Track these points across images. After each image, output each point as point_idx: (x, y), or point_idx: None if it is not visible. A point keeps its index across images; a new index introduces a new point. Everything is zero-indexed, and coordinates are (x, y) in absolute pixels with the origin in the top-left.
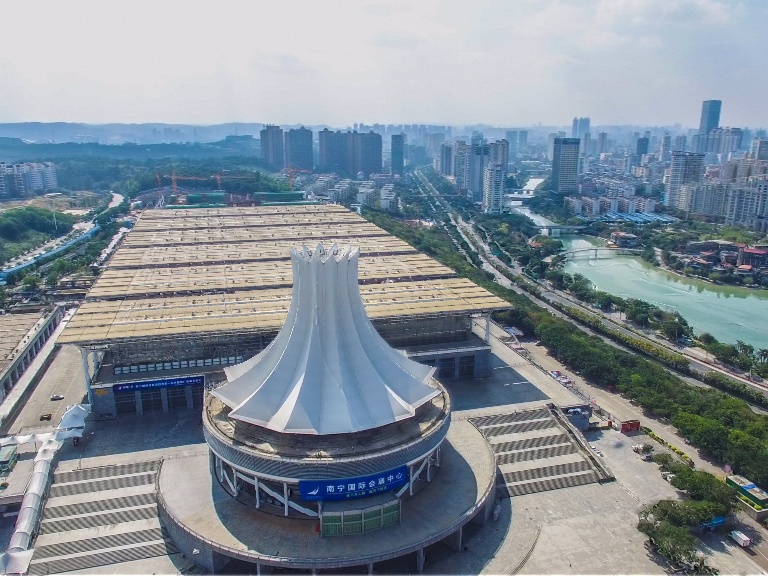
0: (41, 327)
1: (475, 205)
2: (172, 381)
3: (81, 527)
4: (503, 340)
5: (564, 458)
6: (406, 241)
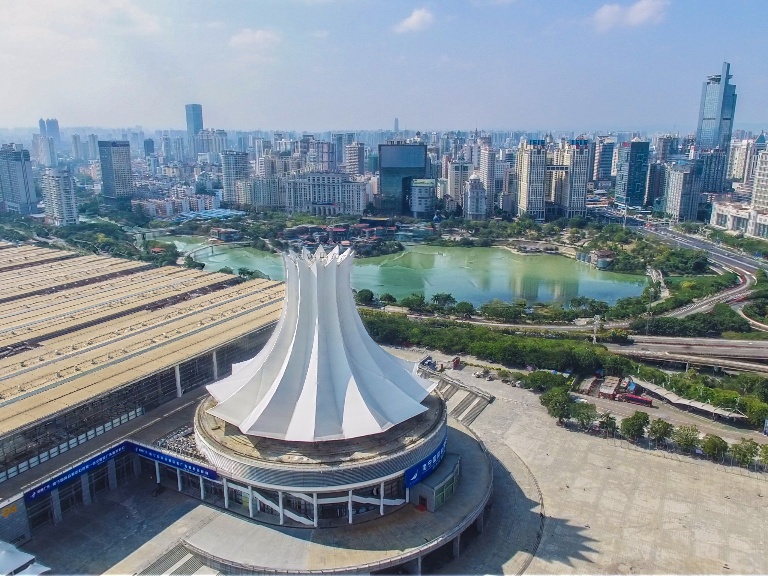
0: None
1: (32, 219)
2: (93, 461)
3: None
4: None
5: (458, 396)
6: None
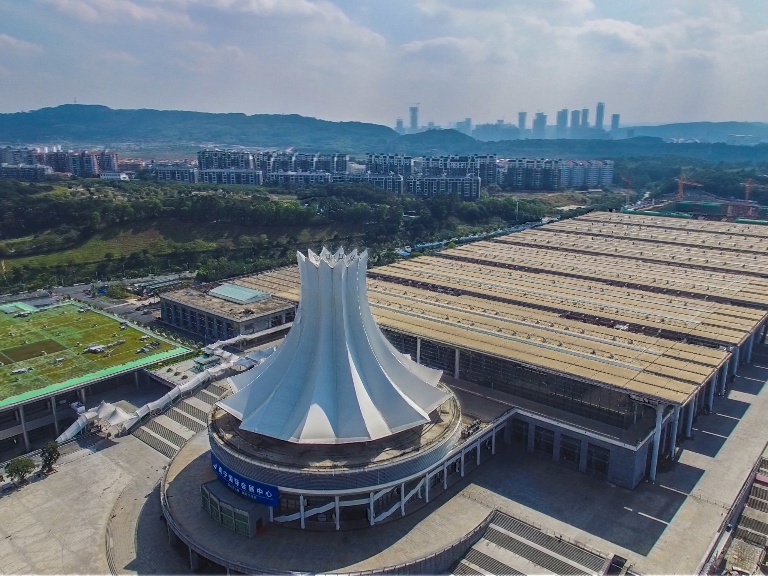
0: None
1: None
2: None
3: (179, 421)
4: (763, 464)
5: None
6: None
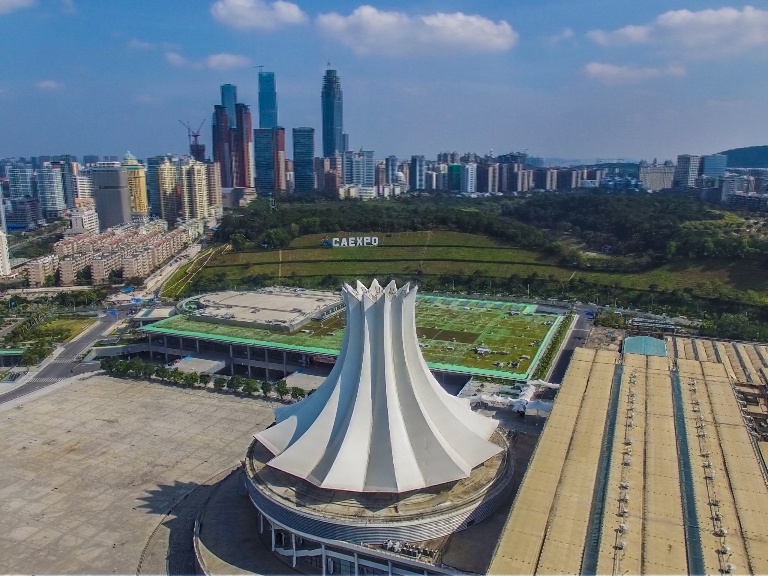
0: None
1: None
2: None
3: None
4: None
5: None
6: None
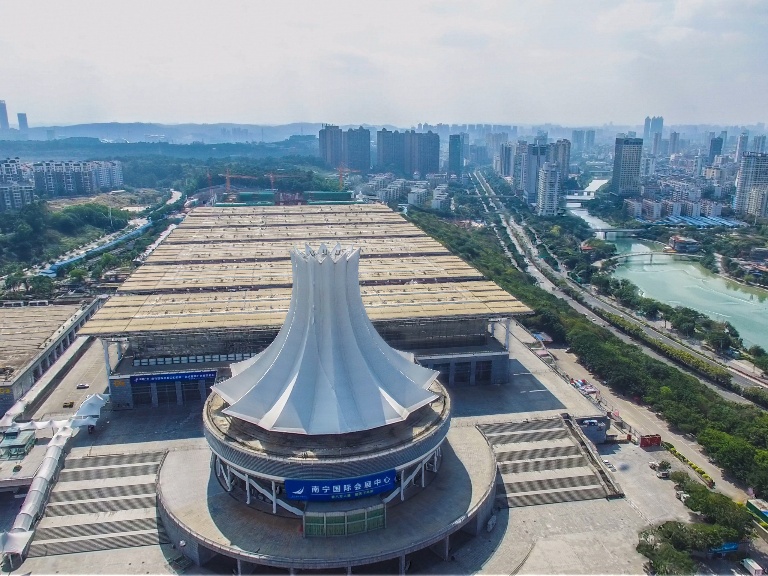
0: (77, 318)
1: (530, 206)
2: (186, 375)
3: (83, 512)
4: (529, 346)
5: (572, 471)
6: (443, 242)
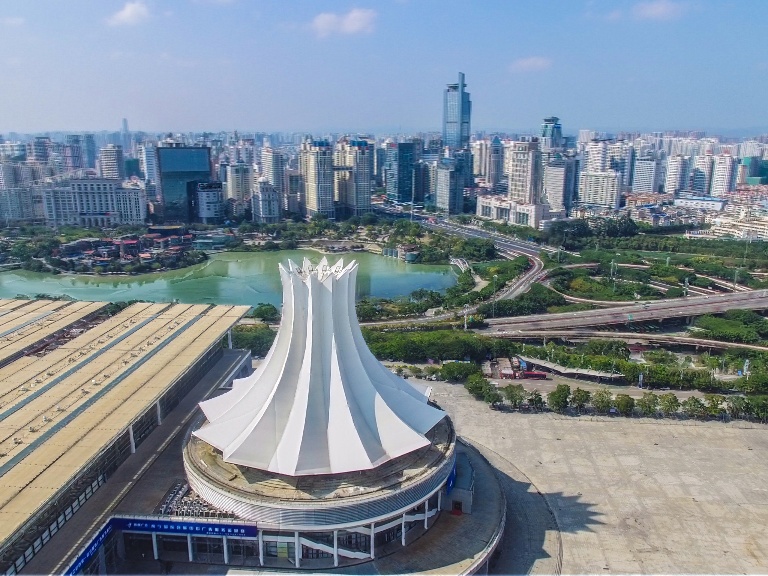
0: None
1: None
2: (87, 552)
3: None
4: None
5: None
6: None
